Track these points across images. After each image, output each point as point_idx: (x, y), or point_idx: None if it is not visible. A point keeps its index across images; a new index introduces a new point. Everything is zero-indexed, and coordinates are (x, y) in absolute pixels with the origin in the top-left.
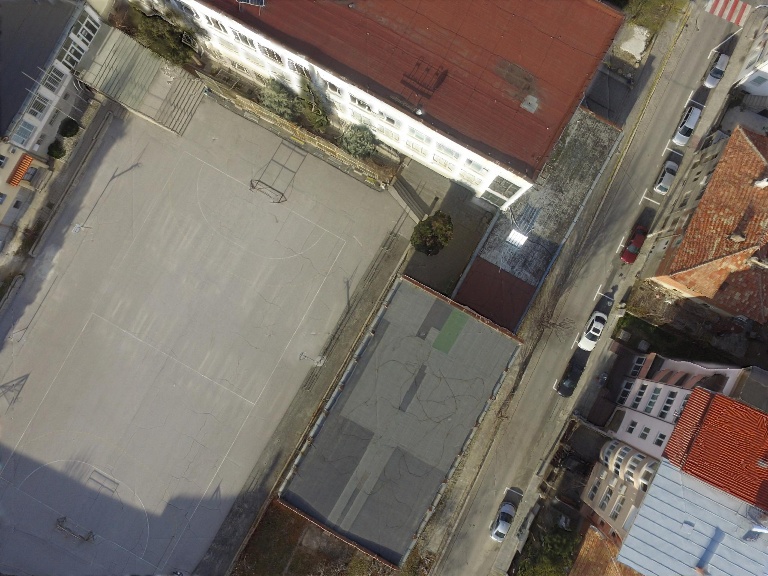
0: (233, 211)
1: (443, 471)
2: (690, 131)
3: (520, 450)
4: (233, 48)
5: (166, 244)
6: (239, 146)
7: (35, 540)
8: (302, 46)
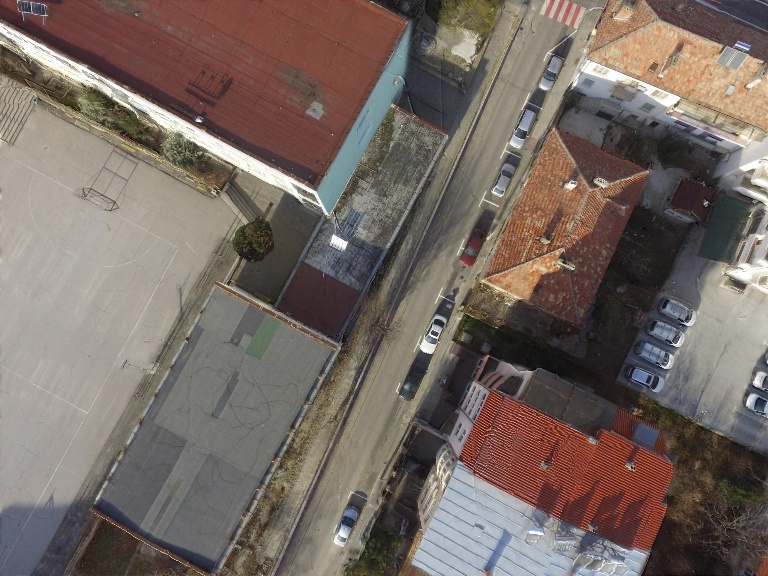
0: (65, 219)
1: (257, 477)
2: (525, 133)
3: (364, 454)
4: (45, 57)
5: None
6: (71, 154)
7: None
8: (86, 55)
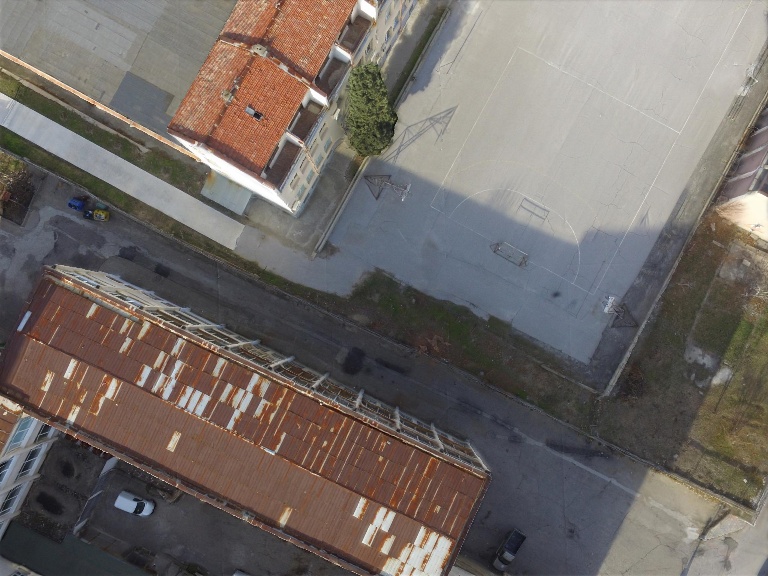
0: None
1: None
2: None
3: None
4: None
5: None
6: None
7: (468, 266)
8: None
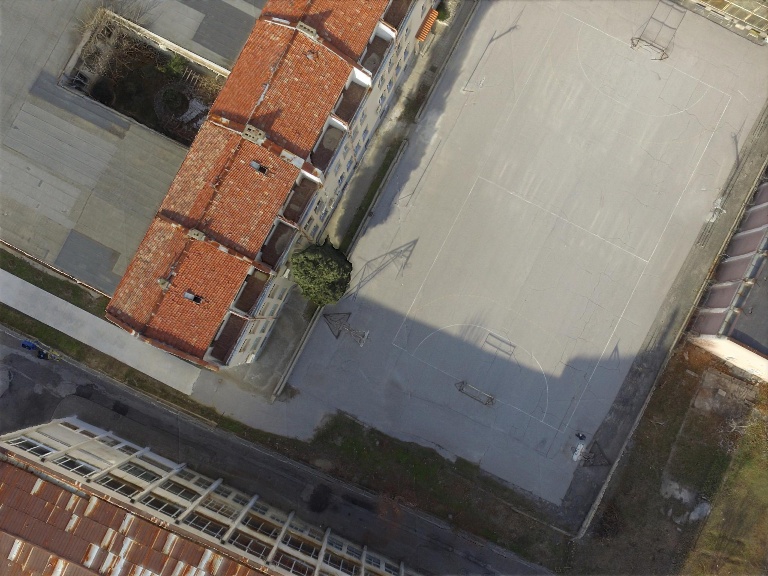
0: (614, 70)
1: None
2: None
3: None
4: None
5: (549, 105)
6: (617, 5)
7: (433, 406)
8: None
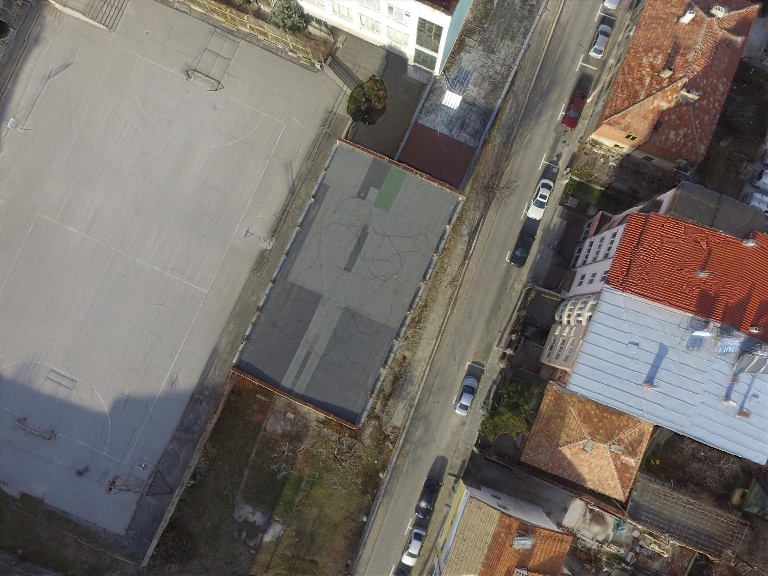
0: (171, 102)
1: (393, 328)
2: None
3: (478, 324)
4: None
5: (107, 140)
6: (172, 38)
7: None
8: None
